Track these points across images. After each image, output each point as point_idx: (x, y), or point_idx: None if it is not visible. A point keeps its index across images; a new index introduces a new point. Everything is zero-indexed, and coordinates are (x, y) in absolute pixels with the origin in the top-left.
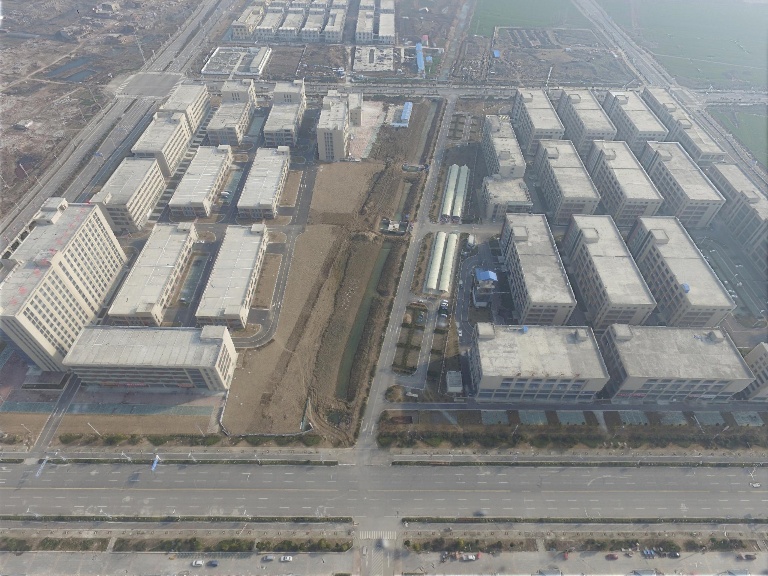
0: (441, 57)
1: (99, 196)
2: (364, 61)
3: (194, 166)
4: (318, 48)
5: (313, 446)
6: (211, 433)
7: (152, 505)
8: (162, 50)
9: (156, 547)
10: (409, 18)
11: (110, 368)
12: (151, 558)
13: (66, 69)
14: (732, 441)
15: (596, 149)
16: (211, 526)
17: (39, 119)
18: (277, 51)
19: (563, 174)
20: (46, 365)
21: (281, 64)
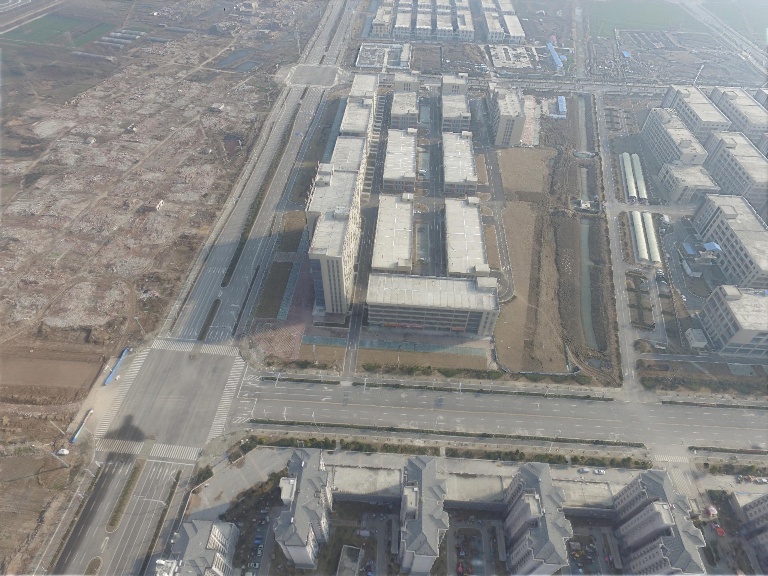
0: (573, 56)
1: None
2: (502, 58)
3: (391, 146)
4: (453, 46)
5: (586, 385)
6: (492, 369)
7: (464, 423)
8: (312, 45)
9: (483, 456)
10: (529, 20)
11: (403, 309)
12: (482, 464)
13: (233, 60)
14: None
15: (767, 141)
16: (522, 443)
17: (227, 103)
18: (416, 48)
19: (746, 162)
20: (332, 307)
21: (425, 60)
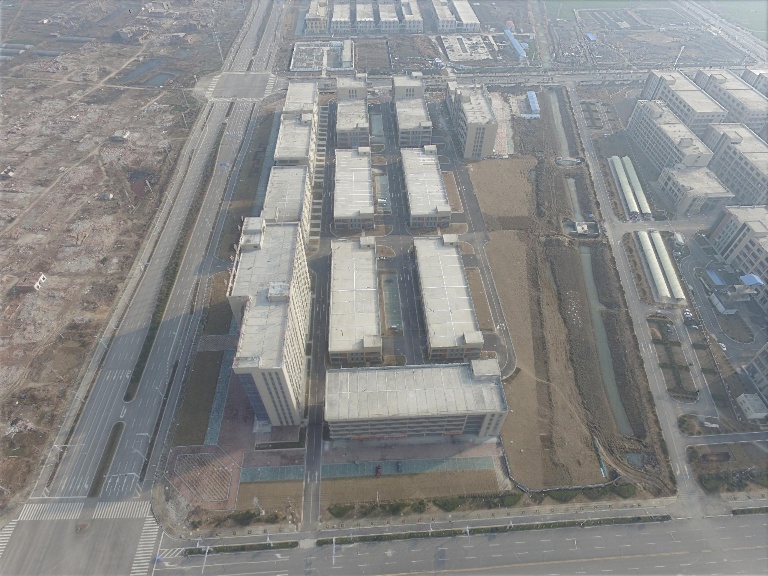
0: (535, 43)
1: (268, 212)
2: (457, 50)
3: (340, 172)
4: (401, 39)
5: (631, 498)
6: (505, 490)
7: None
8: (237, 48)
9: None
10: (480, 4)
11: (377, 420)
12: None
13: (141, 73)
14: None
15: None
16: None
17: (134, 129)
18: (359, 44)
19: (757, 160)
20: (280, 419)
21: (371, 57)
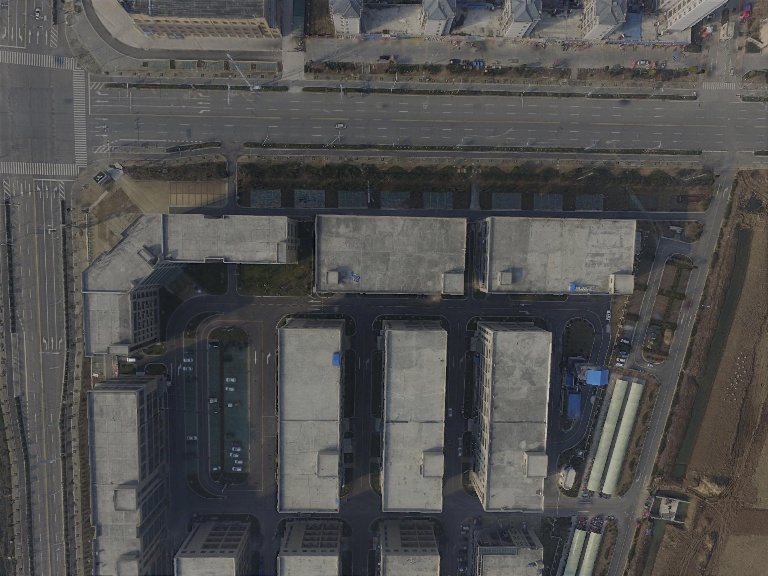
0: None
1: None
2: None
3: None
4: None
5: None
6: None
7: None
8: None
9: None
10: None
11: None
12: None
13: None
14: (342, 172)
15: None
16: None
17: None
18: None
19: None
20: None
21: None
